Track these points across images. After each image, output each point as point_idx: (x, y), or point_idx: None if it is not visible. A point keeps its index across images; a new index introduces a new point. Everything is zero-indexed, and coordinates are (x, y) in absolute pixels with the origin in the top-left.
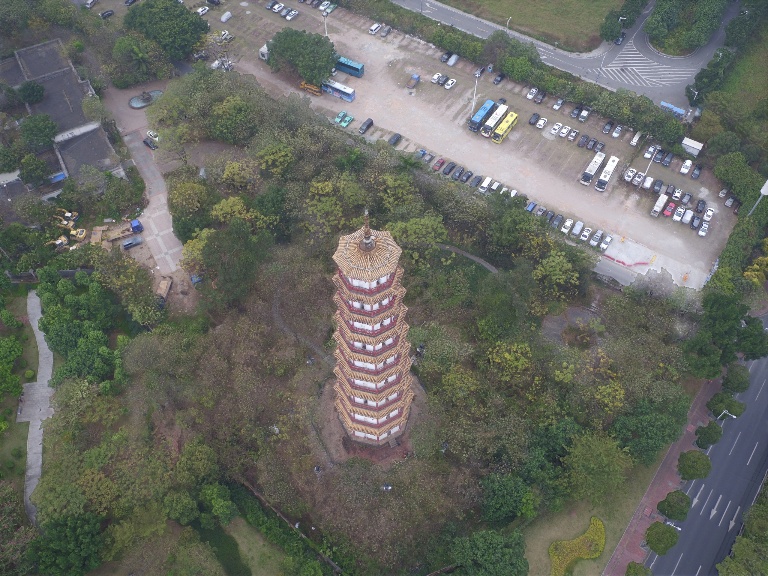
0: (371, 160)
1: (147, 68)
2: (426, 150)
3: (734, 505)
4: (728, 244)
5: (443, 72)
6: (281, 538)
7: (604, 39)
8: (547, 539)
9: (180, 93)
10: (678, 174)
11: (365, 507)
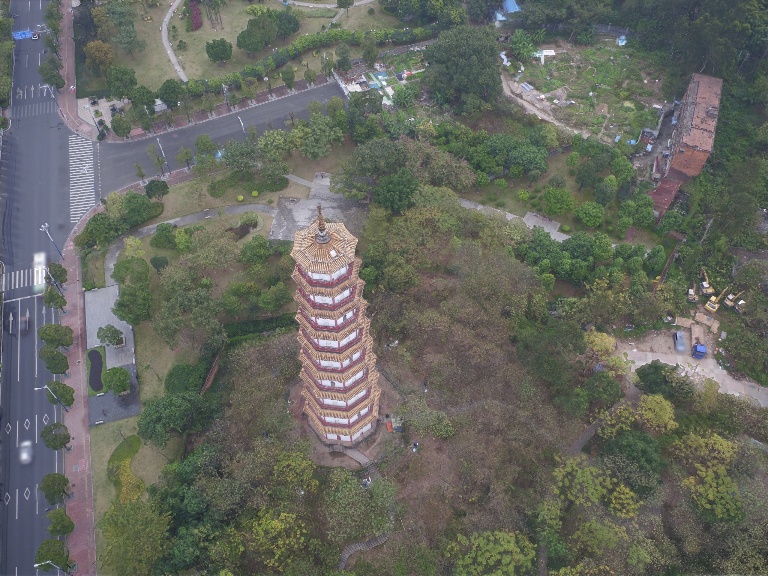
0: None
1: None
2: None
3: None
4: None
5: None
6: None
7: None
8: None
9: None
10: None
11: None
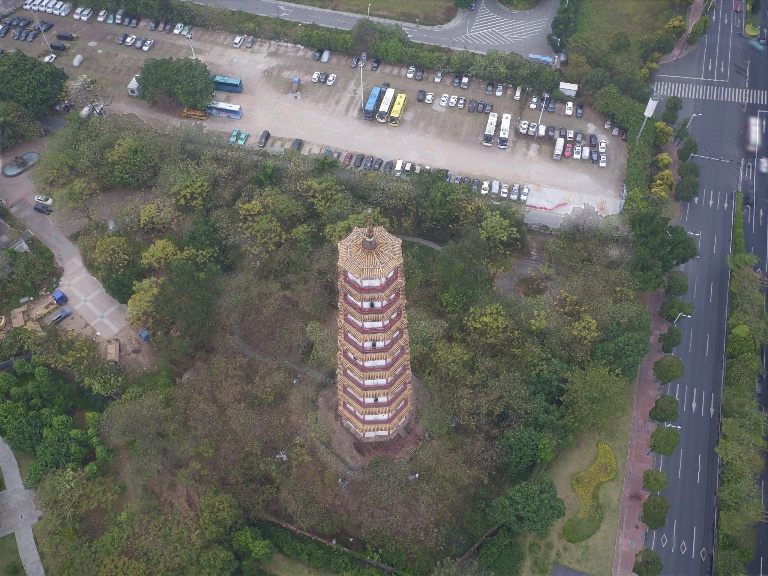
0: (285, 170)
1: (13, 131)
2: (330, 148)
3: (708, 394)
4: (629, 168)
5: (320, 70)
6: (325, 559)
7: (458, 8)
8: (567, 475)
9: (63, 148)
10: (564, 117)
11: (401, 501)
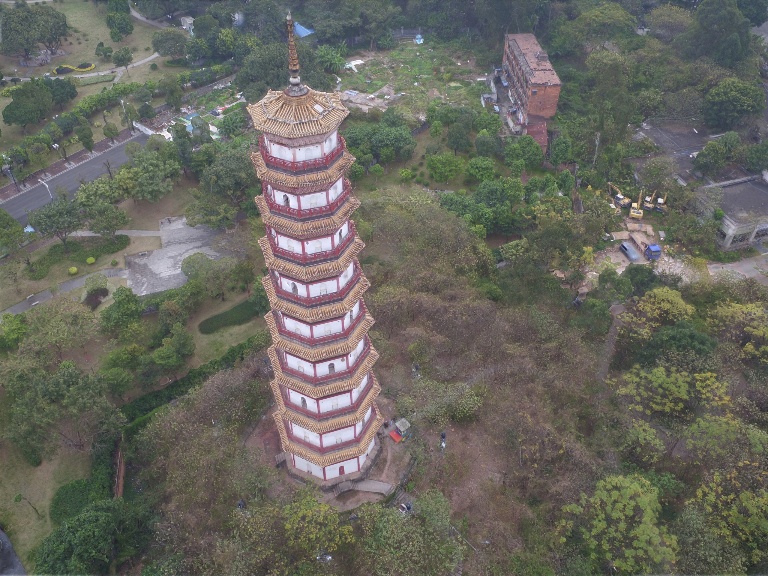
0: None
1: None
2: None
3: None
4: None
5: None
6: (228, 356)
7: None
8: None
9: None
10: None
11: None
